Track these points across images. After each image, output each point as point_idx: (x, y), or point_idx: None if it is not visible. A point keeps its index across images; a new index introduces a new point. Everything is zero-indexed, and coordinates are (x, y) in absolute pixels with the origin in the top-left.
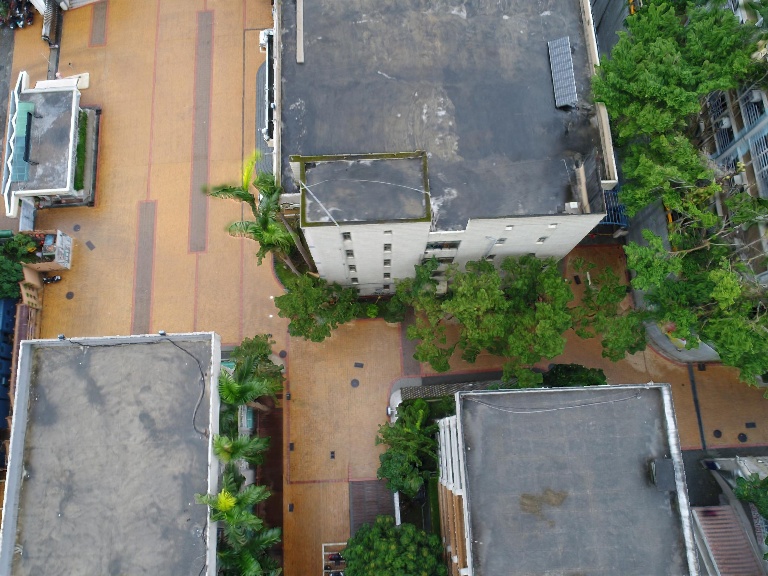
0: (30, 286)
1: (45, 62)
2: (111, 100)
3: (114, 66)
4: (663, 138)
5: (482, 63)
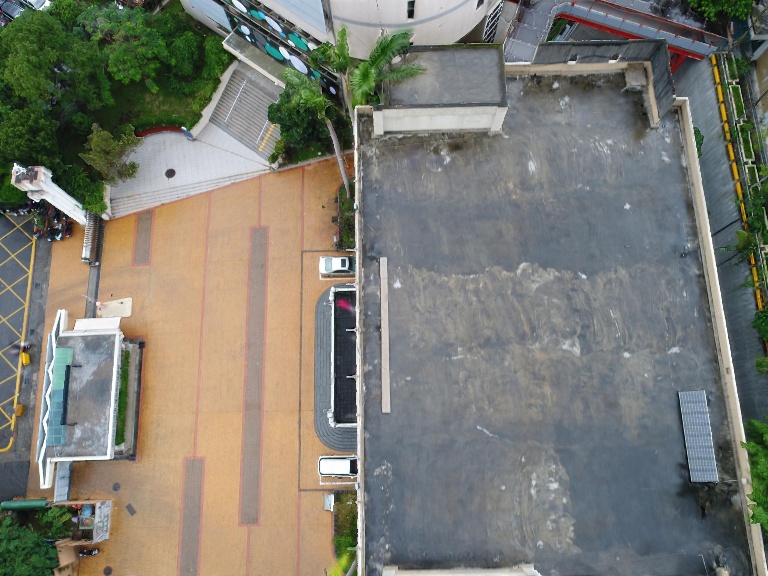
0: (65, 567)
1: (84, 282)
2: (155, 331)
3: (159, 290)
4: None
5: (600, 418)
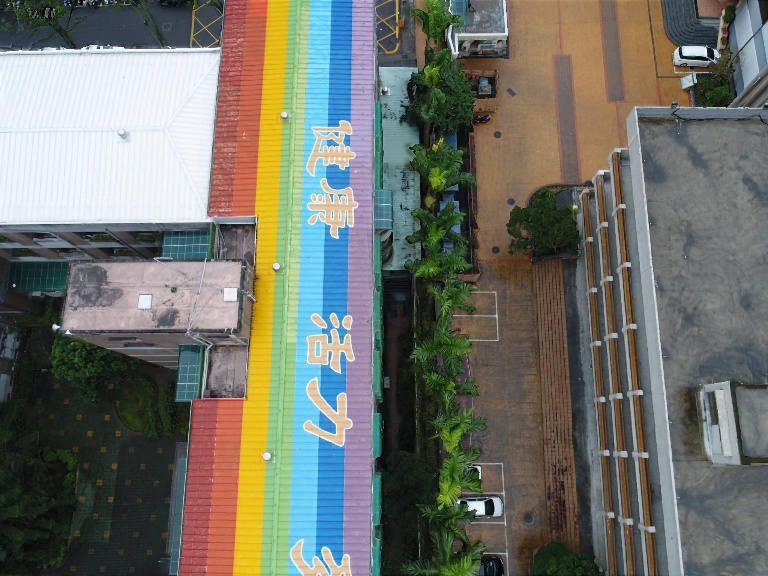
0: None
1: None
2: None
3: None
4: None
5: None
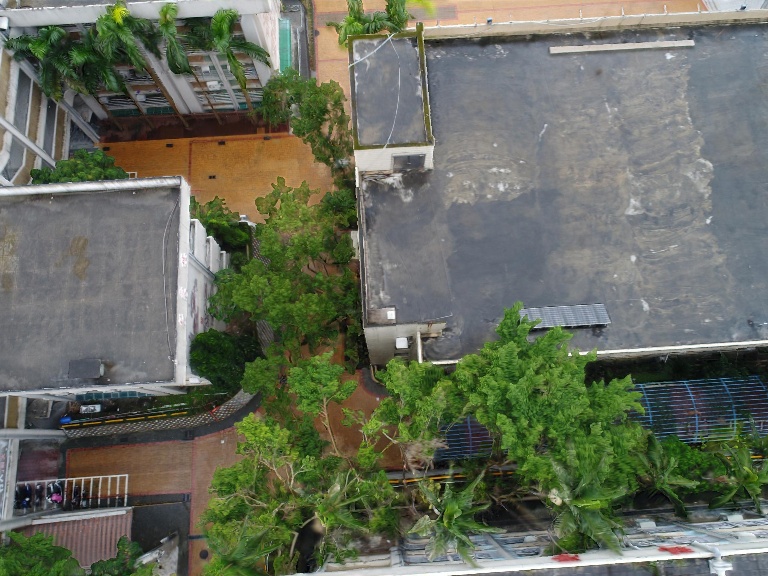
0: None
1: None
2: None
3: None
4: (446, 381)
5: (568, 230)
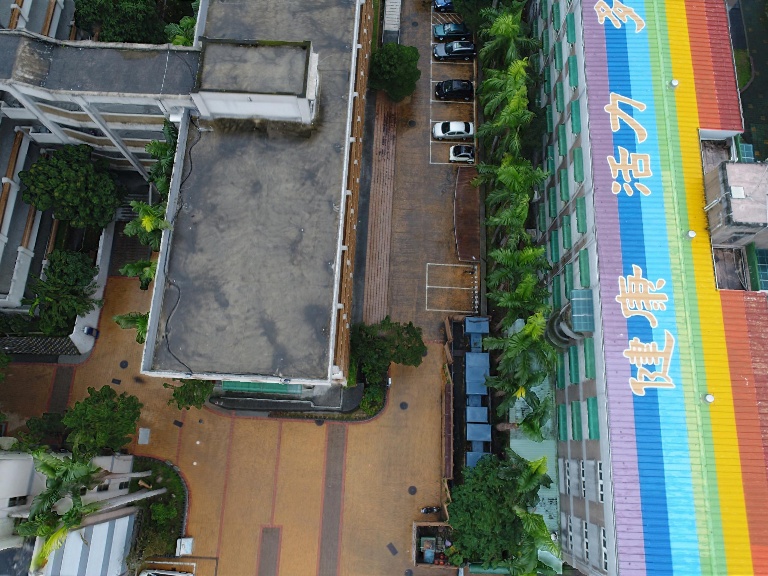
0: None
1: None
2: None
3: None
4: None
5: None
